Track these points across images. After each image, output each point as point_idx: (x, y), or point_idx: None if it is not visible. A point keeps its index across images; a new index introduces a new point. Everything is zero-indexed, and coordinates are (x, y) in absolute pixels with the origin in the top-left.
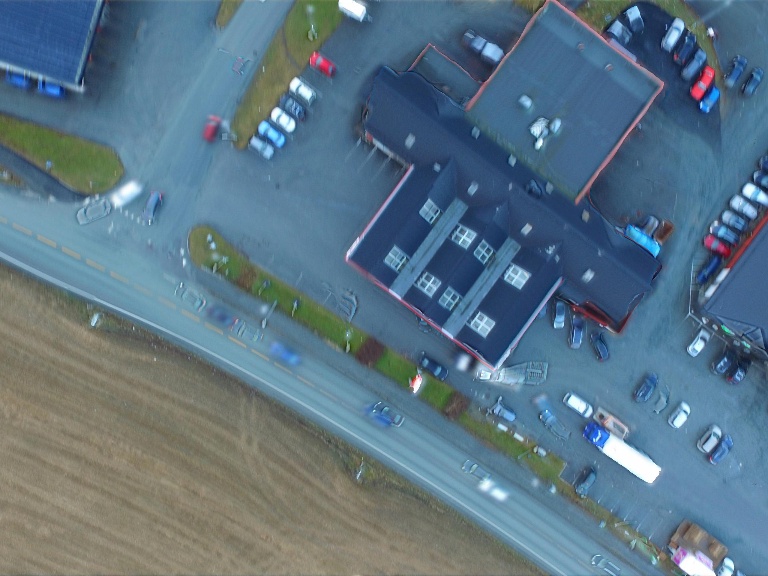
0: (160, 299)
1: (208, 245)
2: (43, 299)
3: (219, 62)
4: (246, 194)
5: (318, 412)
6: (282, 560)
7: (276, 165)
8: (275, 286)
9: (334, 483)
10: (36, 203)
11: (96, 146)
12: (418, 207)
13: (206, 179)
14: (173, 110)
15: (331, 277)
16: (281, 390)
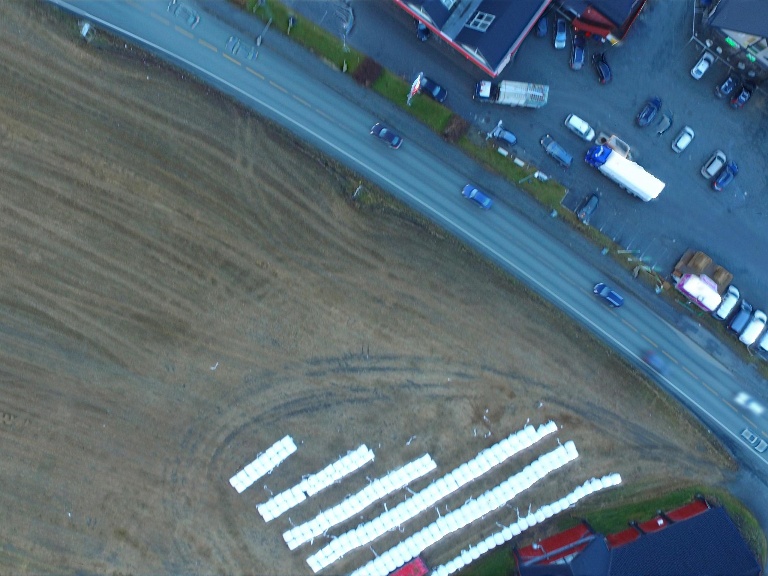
0: (153, 15)
1: None
2: (33, 14)
3: None
4: None
5: (314, 133)
6: (278, 288)
7: None
8: (270, 4)
9: (331, 208)
10: None
11: None
12: None
13: None
14: None
15: None
16: (277, 110)
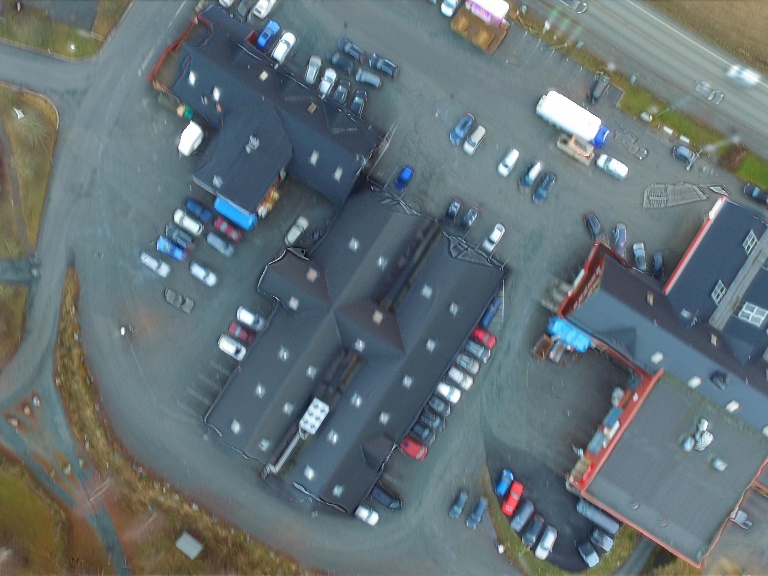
0: None
1: None
2: None
3: None
4: None
5: None
6: None
7: None
8: None
9: None
10: None
11: None
12: None
13: None
14: None
15: None
16: None
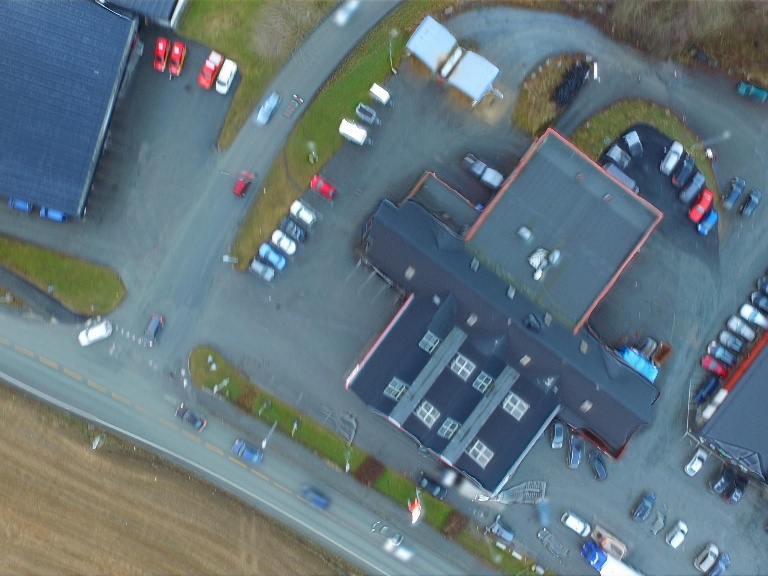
0: (161, 420)
1: (209, 367)
2: (45, 420)
3: (220, 185)
4: (247, 315)
5: (317, 531)
6: None
7: (277, 286)
8: (275, 406)
9: None
10: (38, 325)
11: (98, 268)
12: (417, 339)
13: (207, 300)
14: (174, 232)
15: (331, 400)
16: (281, 509)
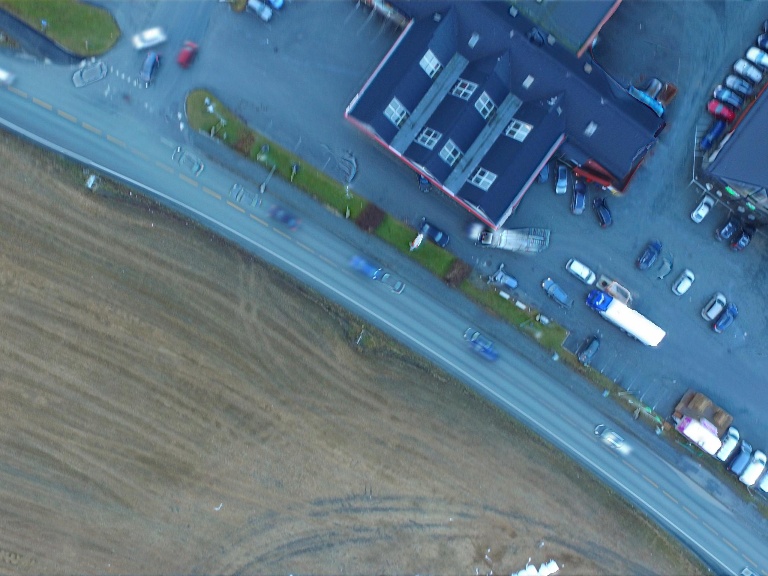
0: (157, 163)
1: (206, 108)
2: (39, 163)
3: None
4: (244, 58)
5: (318, 279)
6: (282, 430)
7: (274, 28)
8: (274, 151)
9: (334, 351)
10: (31, 65)
11: (92, 8)
12: (418, 58)
13: (203, 42)
14: None
15: (330, 139)
16: (280, 256)
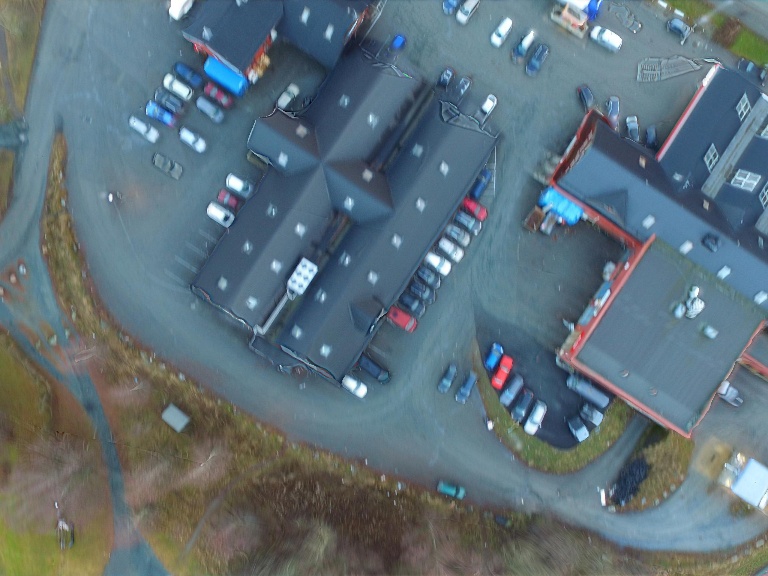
0: None
1: None
2: None
3: None
4: None
5: None
6: None
7: None
8: None
9: None
10: None
11: None
12: None
13: None
14: None
15: None
16: None
